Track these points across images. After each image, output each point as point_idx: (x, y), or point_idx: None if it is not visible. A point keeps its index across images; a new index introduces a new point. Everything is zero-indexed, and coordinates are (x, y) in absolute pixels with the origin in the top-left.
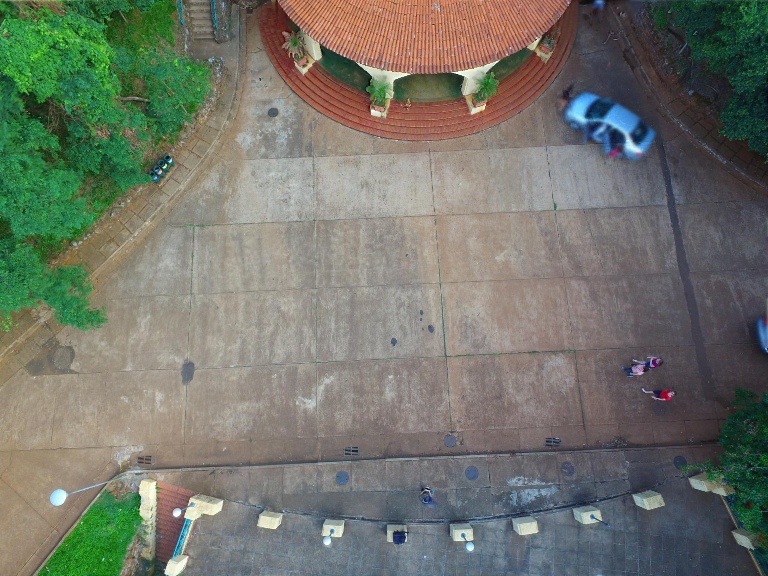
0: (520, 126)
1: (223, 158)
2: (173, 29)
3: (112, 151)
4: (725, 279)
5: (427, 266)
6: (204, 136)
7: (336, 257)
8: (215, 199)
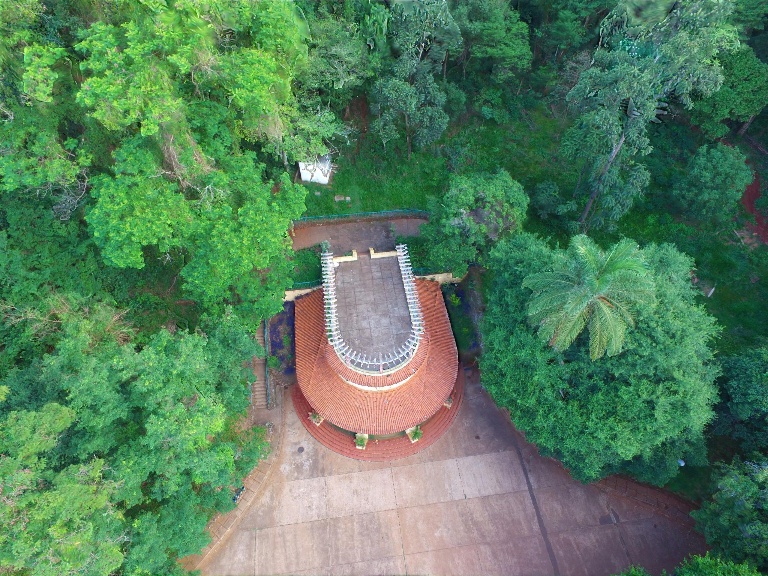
0: (440, 447)
1: (273, 482)
2: (246, 408)
3: (222, 497)
4: (568, 536)
5: (395, 544)
6: (262, 469)
7: (341, 543)
8: (268, 510)
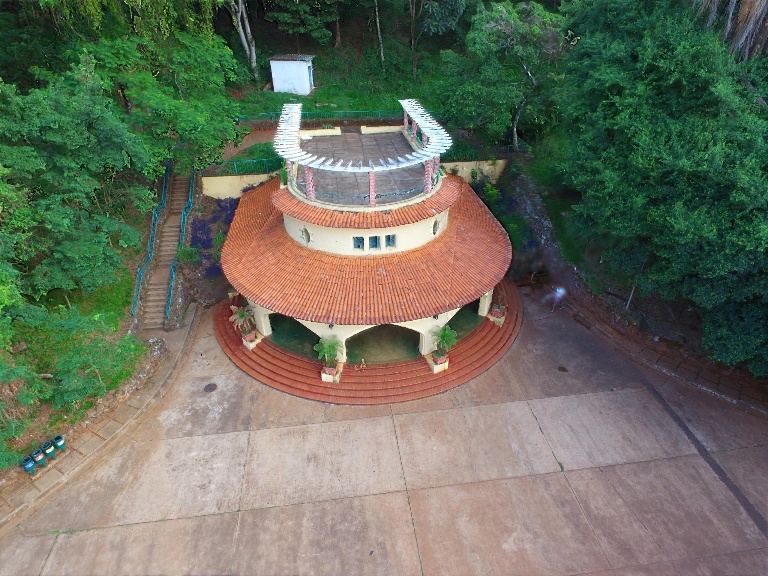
0: (491, 383)
1: (134, 439)
2: (121, 318)
3: None
4: None
5: (403, 568)
6: (119, 416)
7: (264, 565)
8: (105, 492)
